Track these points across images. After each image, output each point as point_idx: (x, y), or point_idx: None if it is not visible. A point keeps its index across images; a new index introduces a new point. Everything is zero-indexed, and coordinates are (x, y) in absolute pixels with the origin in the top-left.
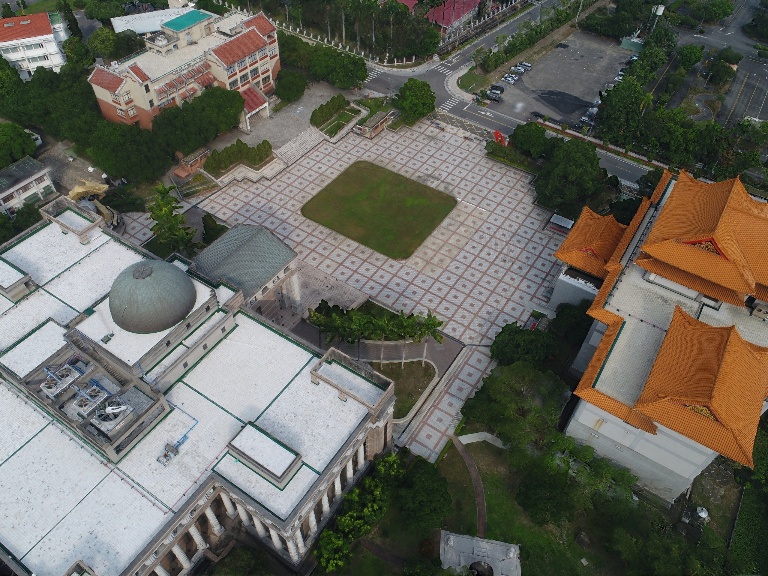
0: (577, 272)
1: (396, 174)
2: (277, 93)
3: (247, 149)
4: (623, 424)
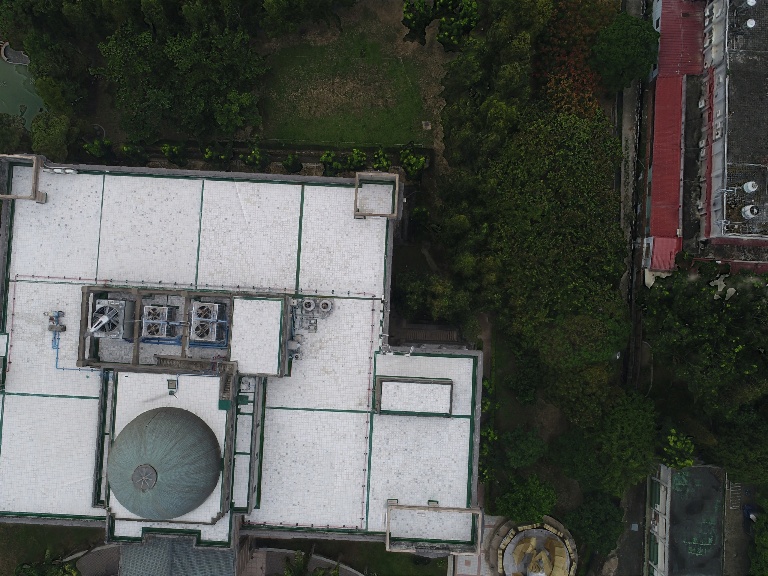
0: None
1: None
2: None
3: None
4: None
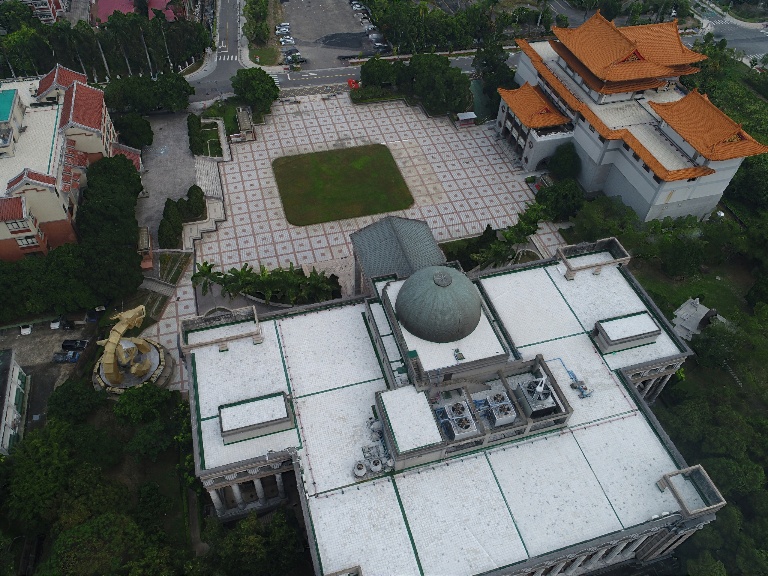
0: (540, 132)
1: (316, 153)
2: (133, 143)
3: (185, 203)
4: (687, 184)
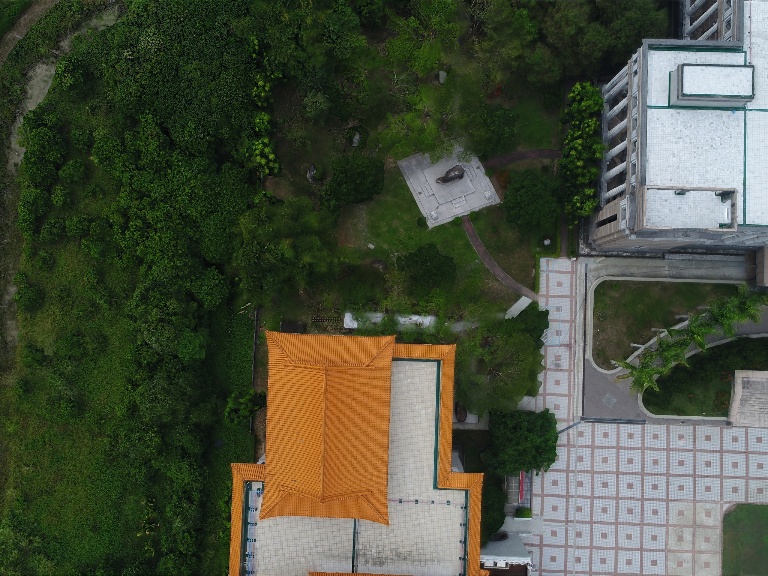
0: None
1: None
2: None
3: None
4: None
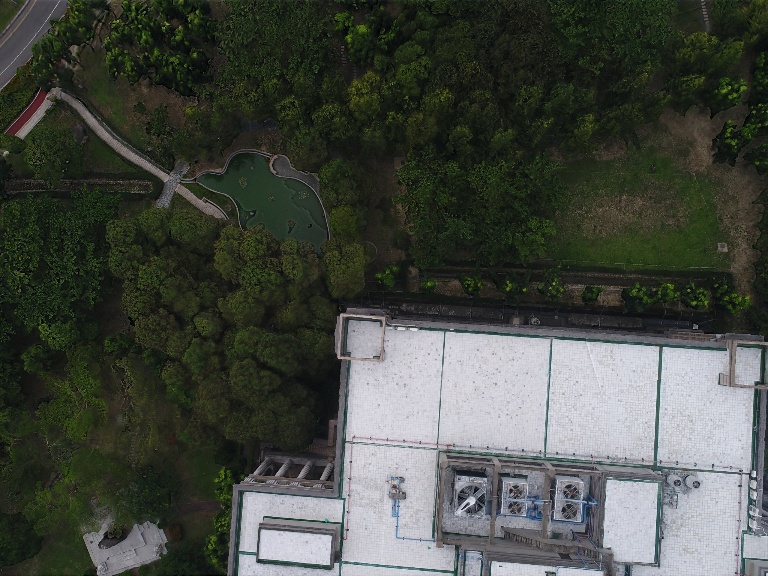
0: None
1: None
2: None
3: None
4: None
